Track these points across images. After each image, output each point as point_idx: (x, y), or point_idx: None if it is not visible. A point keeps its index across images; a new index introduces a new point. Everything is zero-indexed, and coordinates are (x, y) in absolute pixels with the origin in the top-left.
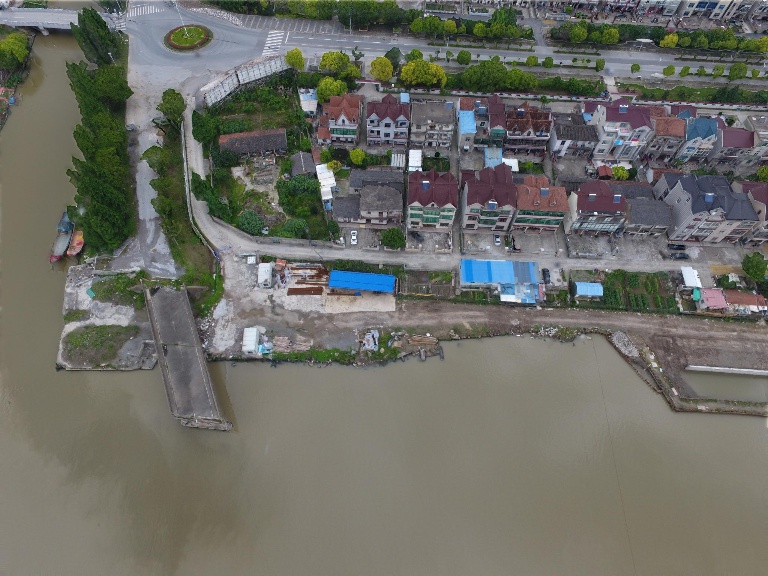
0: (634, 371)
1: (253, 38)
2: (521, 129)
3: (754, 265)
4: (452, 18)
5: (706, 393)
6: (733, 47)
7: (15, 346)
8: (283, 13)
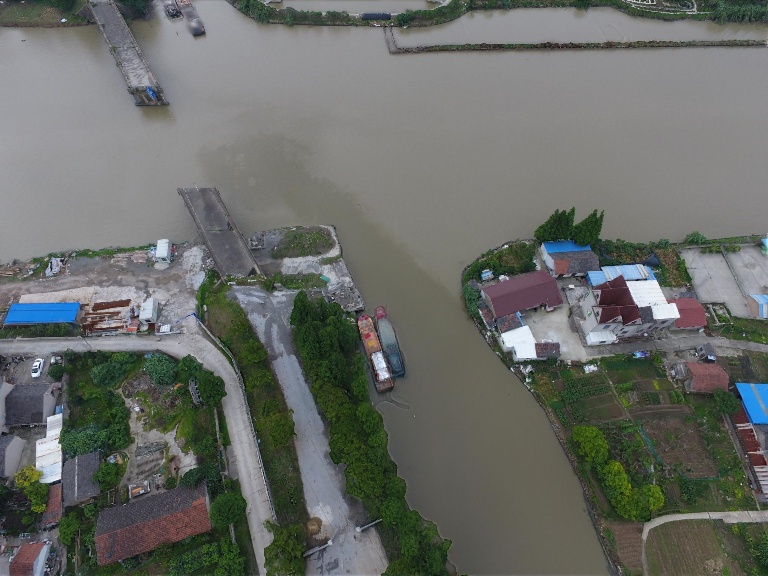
0: None
1: None
2: None
3: None
4: None
5: None
6: None
7: (378, 239)
8: None
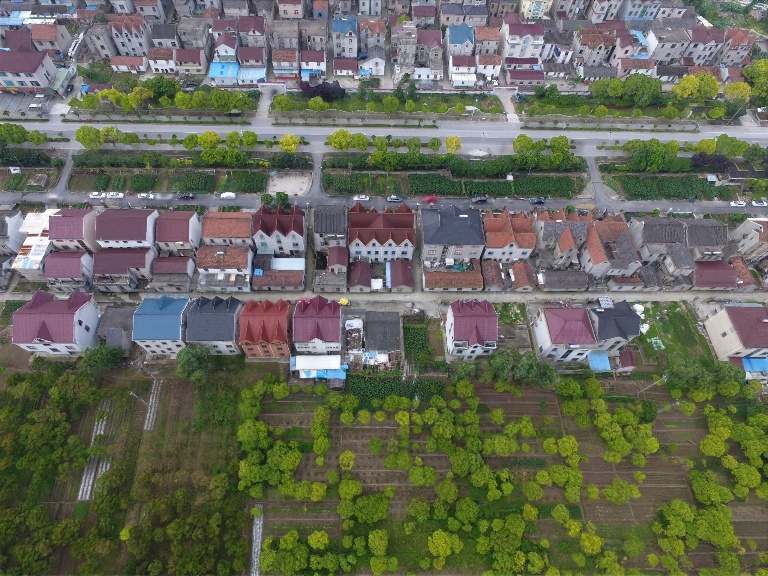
0: None
1: None
2: None
3: None
4: (711, 157)
5: None
6: None
7: None
8: None
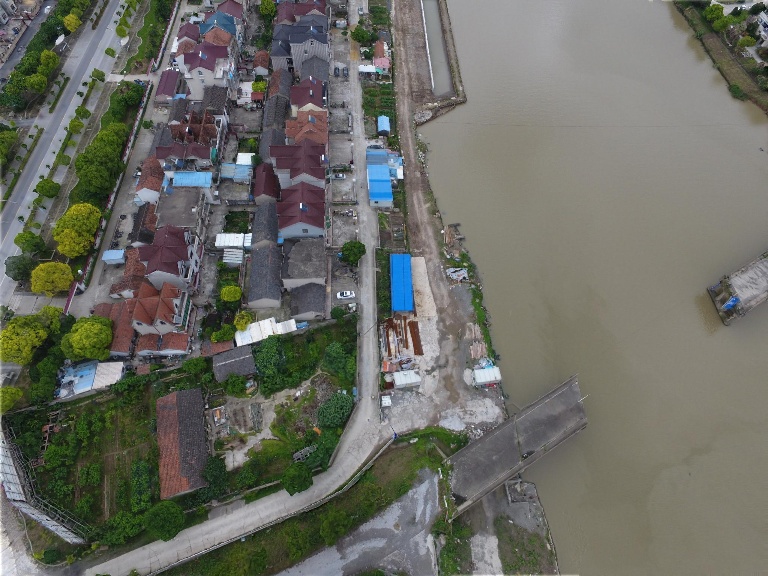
0: (442, 116)
1: None
2: (209, 137)
3: (361, 33)
4: None
5: (447, 87)
6: None
7: None
8: None
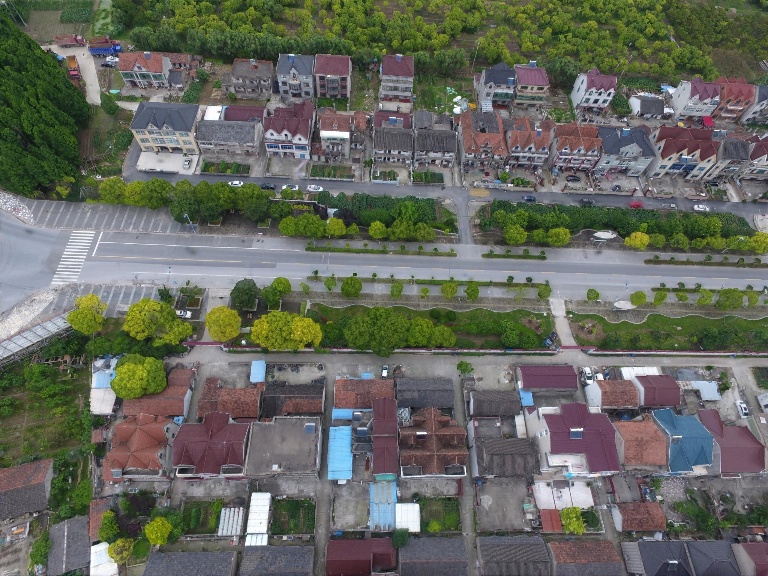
0: None
1: (44, 248)
2: (422, 464)
3: None
4: (339, 210)
5: None
6: (721, 248)
7: None
8: (98, 197)
